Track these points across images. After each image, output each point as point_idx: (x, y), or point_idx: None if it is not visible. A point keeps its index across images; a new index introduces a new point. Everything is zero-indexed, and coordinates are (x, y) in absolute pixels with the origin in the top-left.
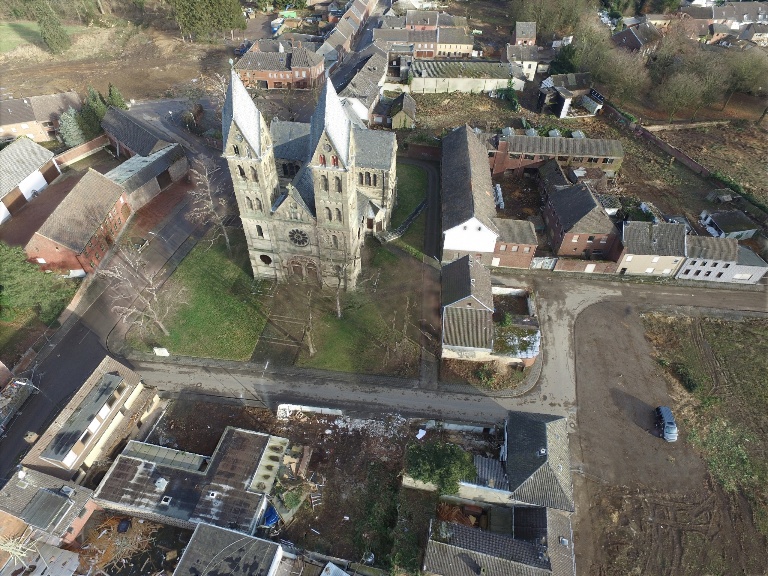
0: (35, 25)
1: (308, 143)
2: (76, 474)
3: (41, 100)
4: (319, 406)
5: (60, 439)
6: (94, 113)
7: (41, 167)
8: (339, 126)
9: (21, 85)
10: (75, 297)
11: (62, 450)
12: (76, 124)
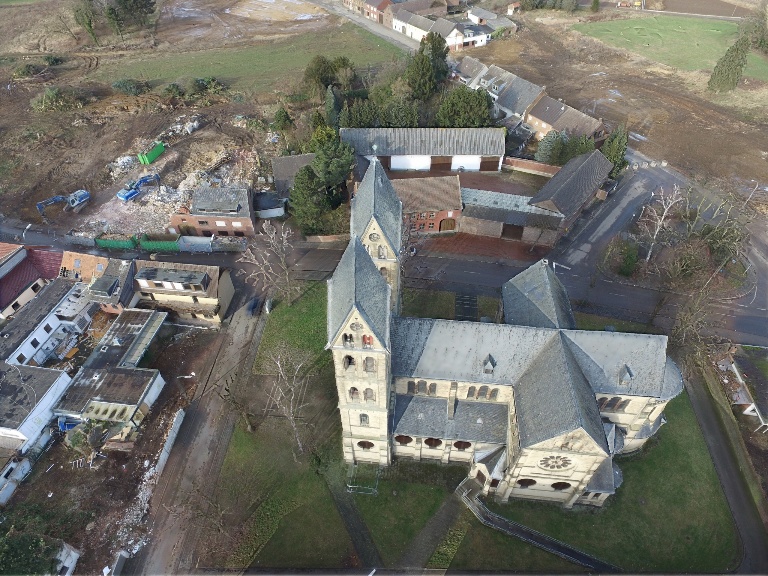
0: (758, 59)
1: (528, 316)
2: (146, 294)
3: (573, 114)
4: (182, 450)
5: (153, 271)
6: (577, 146)
7: (485, 156)
8: (343, 297)
9: (632, 99)
10: (332, 236)
11: (143, 275)
12: (553, 145)
